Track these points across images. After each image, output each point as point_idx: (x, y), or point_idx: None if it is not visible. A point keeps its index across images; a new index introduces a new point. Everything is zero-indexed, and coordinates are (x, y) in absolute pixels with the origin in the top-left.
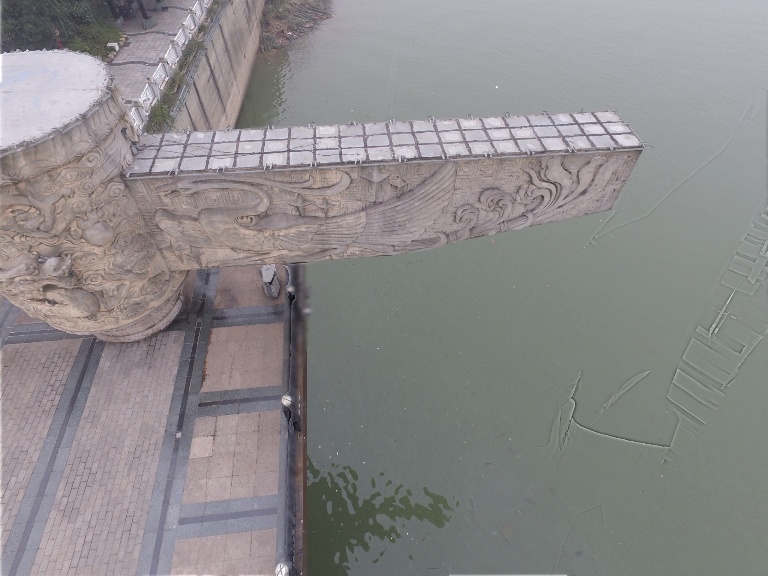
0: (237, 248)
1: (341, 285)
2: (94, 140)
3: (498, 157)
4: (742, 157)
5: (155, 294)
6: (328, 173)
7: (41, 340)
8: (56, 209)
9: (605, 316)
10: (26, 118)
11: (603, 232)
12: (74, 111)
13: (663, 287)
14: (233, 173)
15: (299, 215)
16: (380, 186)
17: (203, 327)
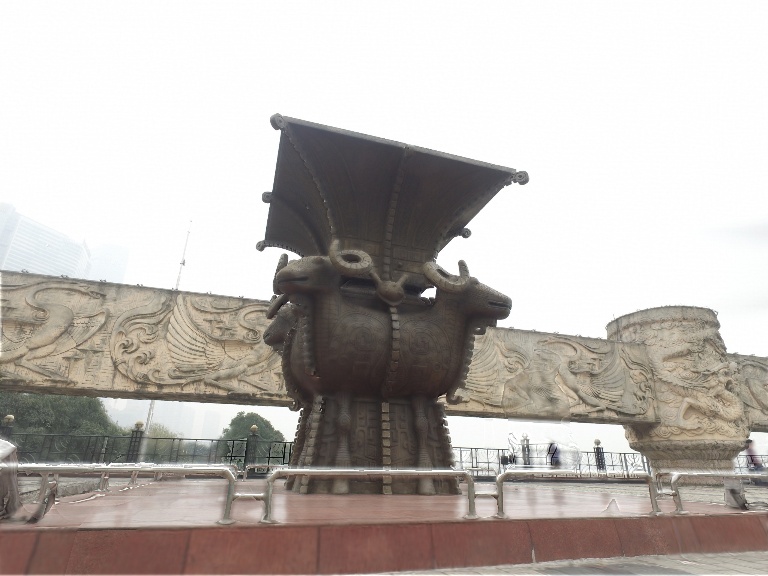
0: (767, 406)
1: None
2: None
3: None
4: None
5: None
6: None
7: None
8: None
9: None
10: None
11: None
12: None
13: None
14: (756, 359)
15: None
16: None
17: None
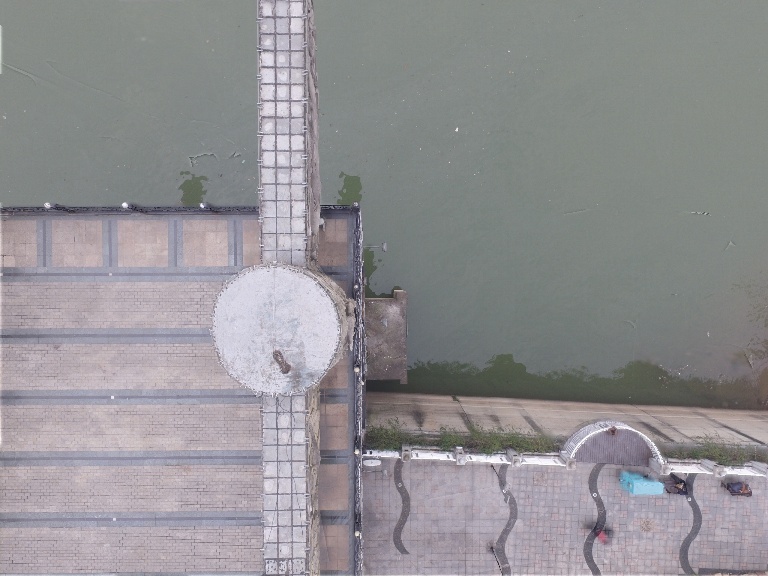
0: None
1: None
2: None
3: None
4: None
5: None
6: None
7: None
8: None
9: None
10: None
11: None
12: None
13: None
14: None
15: None
16: None
17: None
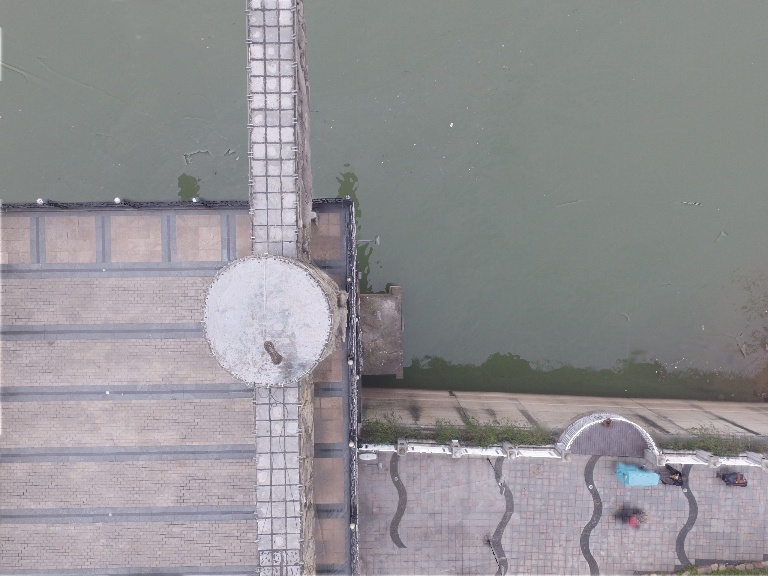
0: None
1: None
2: None
3: None
4: None
5: None
6: None
7: None
8: None
9: None
10: None
11: None
12: None
13: None
14: None
15: None
16: None
17: None
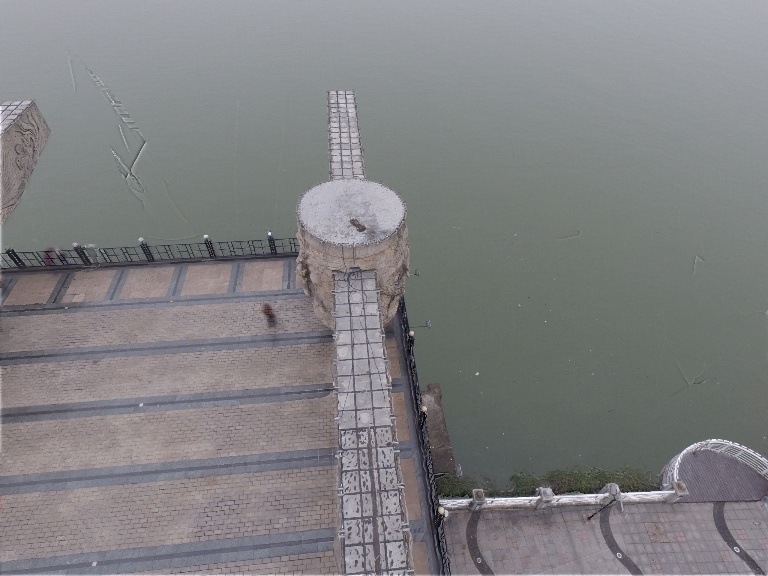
0: None
1: (21, 228)
2: None
3: (6, 131)
4: (74, 63)
5: None
6: None
7: None
8: None
9: (98, 121)
10: None
11: None
12: None
13: (96, 100)
14: None
15: None
16: None
17: None
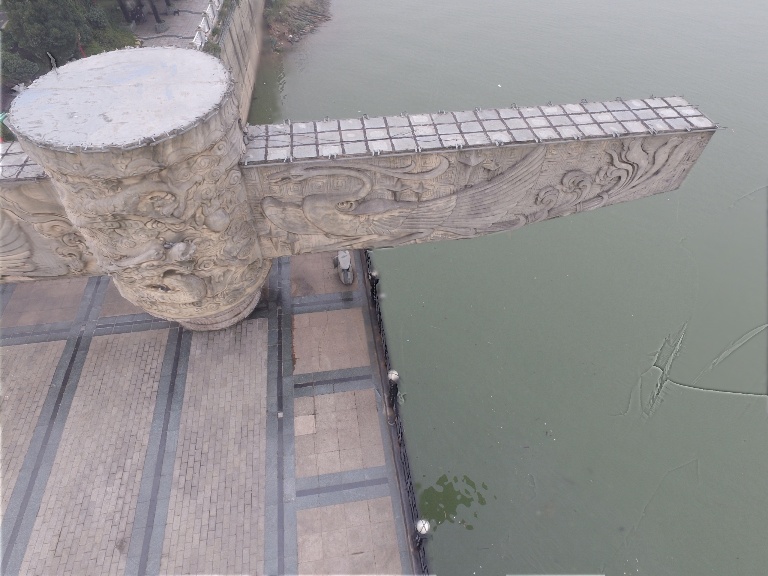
0: (332, 233)
1: (424, 268)
2: (224, 129)
3: (585, 140)
4: None
5: (251, 281)
6: (429, 158)
7: (129, 331)
8: (188, 195)
9: (729, 275)
10: (166, 109)
11: (744, 194)
12: (209, 101)
13: None
14: (342, 160)
15: (394, 200)
16: (474, 170)
17: (284, 314)
